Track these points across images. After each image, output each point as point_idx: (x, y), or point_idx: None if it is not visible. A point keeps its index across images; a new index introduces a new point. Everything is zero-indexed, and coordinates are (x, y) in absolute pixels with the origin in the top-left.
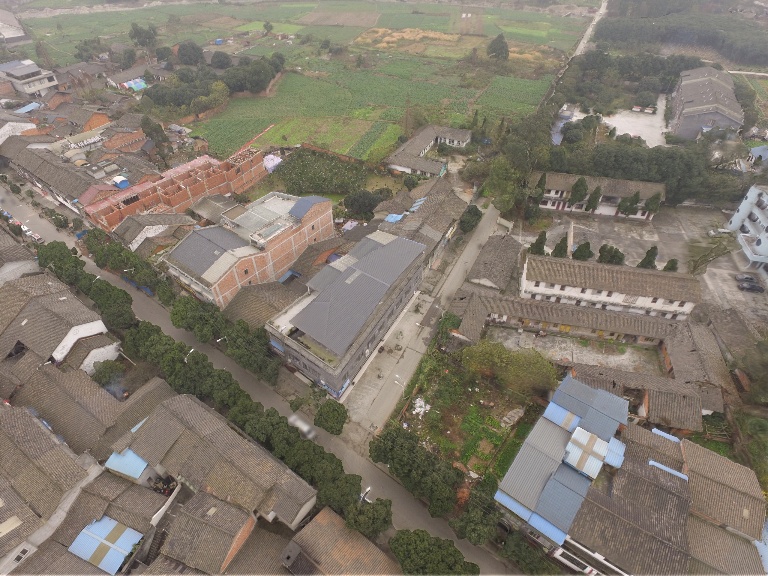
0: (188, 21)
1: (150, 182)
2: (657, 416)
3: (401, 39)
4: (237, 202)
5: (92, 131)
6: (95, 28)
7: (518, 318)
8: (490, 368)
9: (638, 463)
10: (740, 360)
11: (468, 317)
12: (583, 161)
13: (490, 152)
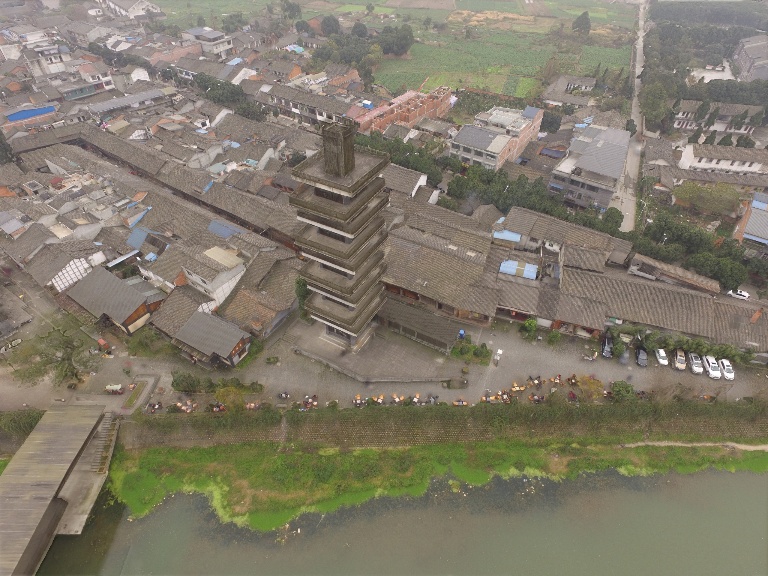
0: None
1: None
2: None
3: (486, 19)
4: (447, 122)
5: None
6: (211, 8)
7: (691, 181)
8: (697, 196)
9: None
10: None
11: (663, 177)
12: (701, 91)
13: None
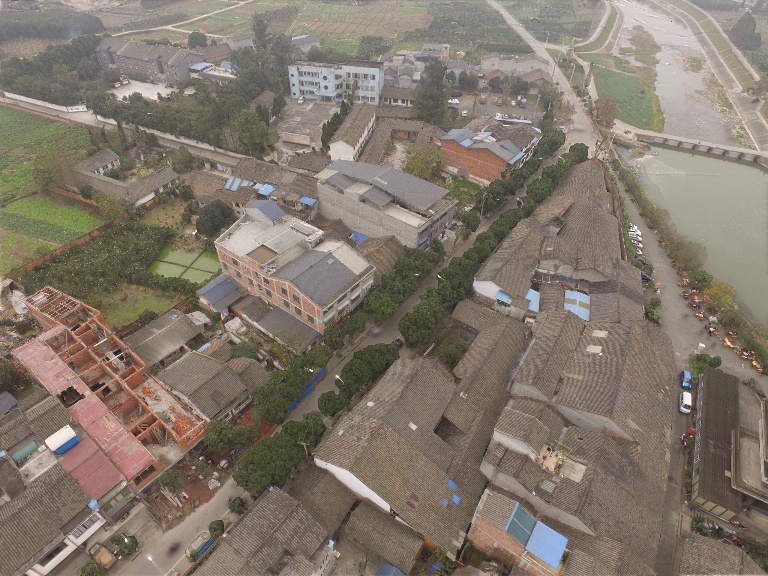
0: None
1: (78, 402)
2: None
3: None
4: (152, 321)
5: None
6: None
7: None
8: None
9: None
10: (415, 110)
11: None
12: None
13: None
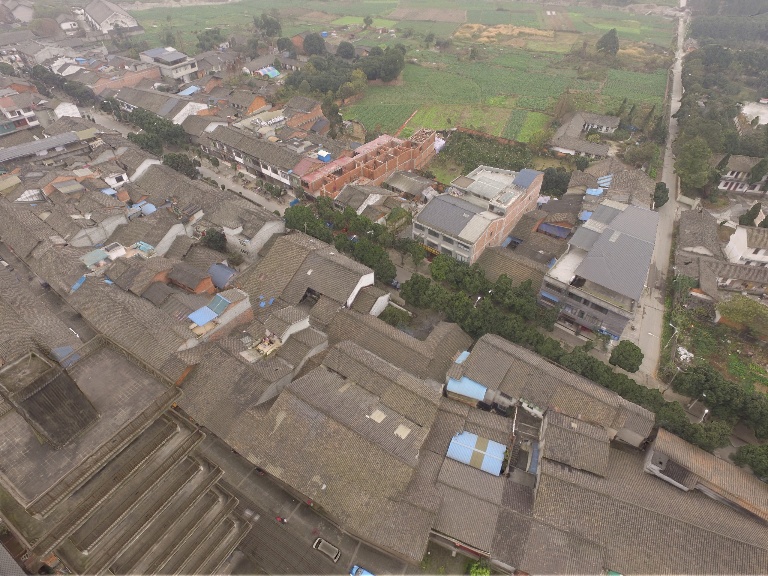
0: (282, 15)
1: (348, 157)
2: None
3: (498, 34)
4: (425, 177)
5: None
6: (197, 20)
7: (742, 282)
8: (754, 319)
9: None
10: None
11: (704, 278)
12: (758, 144)
13: (639, 138)
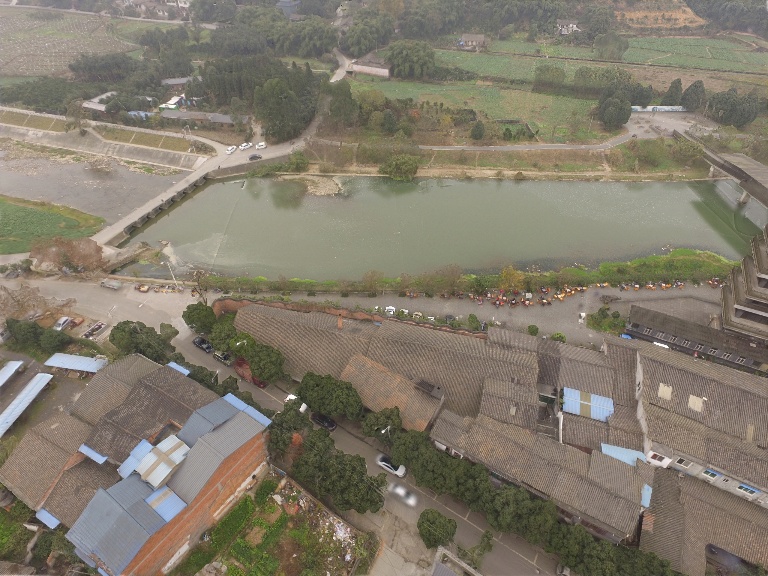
0: None
1: None
2: (20, 574)
3: None
4: None
5: None
6: None
7: None
8: None
9: (119, 454)
10: None
11: None
12: None
13: None
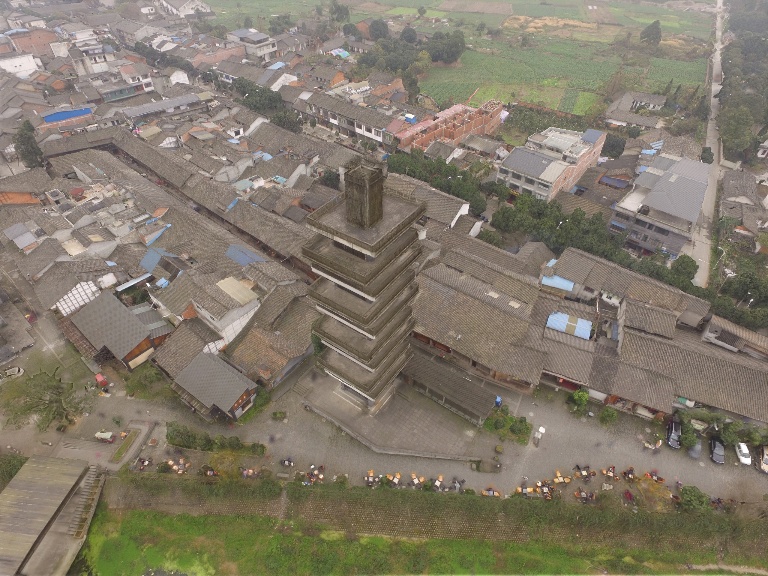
0: None
1: (431, 120)
2: None
3: (544, 25)
4: (496, 140)
5: (364, 81)
6: (261, 8)
7: None
8: None
9: None
10: None
11: (746, 219)
12: None
13: None
